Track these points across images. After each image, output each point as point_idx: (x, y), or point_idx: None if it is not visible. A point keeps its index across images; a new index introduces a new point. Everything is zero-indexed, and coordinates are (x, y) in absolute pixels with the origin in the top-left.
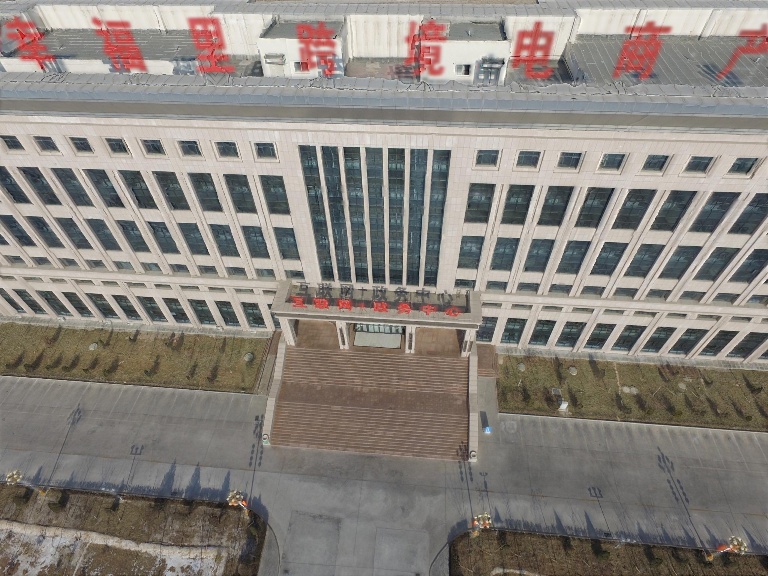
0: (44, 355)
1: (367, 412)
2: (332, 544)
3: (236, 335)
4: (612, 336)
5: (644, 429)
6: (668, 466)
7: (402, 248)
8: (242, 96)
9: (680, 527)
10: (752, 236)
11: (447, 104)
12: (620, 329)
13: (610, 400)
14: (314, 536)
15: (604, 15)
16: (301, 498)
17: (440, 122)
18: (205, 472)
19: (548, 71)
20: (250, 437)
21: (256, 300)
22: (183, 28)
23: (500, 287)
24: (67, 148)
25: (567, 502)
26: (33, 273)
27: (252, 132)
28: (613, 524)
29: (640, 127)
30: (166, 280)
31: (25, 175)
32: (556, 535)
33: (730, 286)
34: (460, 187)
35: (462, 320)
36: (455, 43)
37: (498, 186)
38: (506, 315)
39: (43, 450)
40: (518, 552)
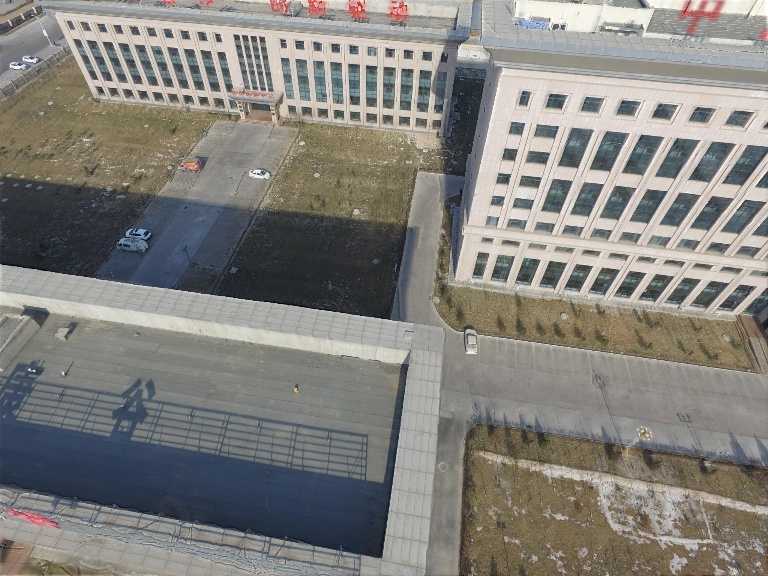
0: (522, 321)
1: None
2: None
3: (700, 316)
4: None
5: None
6: None
7: None
8: None
9: None
10: None
11: None
12: None
13: None
14: None
15: None
16: None
17: None
18: (767, 444)
19: None
20: None
21: (759, 283)
22: None
23: None
24: (759, 124)
25: None
26: (550, 241)
27: None
28: None
29: None
30: (691, 257)
31: (671, 147)
32: None
33: None
34: None
35: None
36: None
37: None
38: None
39: (592, 411)
40: None
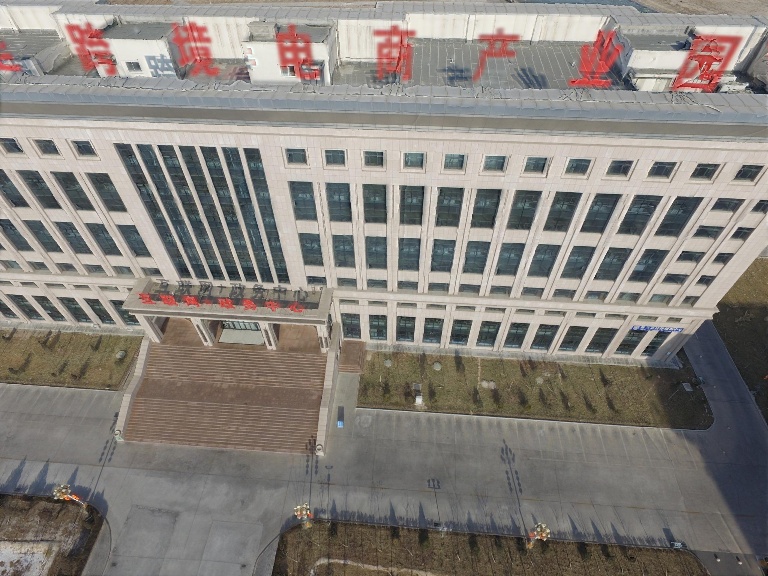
0: None
1: (222, 407)
2: (165, 537)
3: (112, 333)
4: (473, 332)
5: (494, 422)
6: (509, 458)
7: (246, 245)
8: (30, 94)
9: (508, 516)
10: (567, 233)
11: (226, 103)
12: (477, 325)
13: (467, 394)
14: (149, 530)
15: (437, 19)
16: (144, 492)
17: (236, 121)
18: (53, 468)
19: (384, 73)
20: (106, 433)
21: (123, 298)
22: (36, 28)
23: (353, 284)
24: None
25: (404, 493)
26: None
27: (64, 130)
28: (444, 514)
29: (423, 127)
30: (28, 278)
31: None
32: (387, 525)
33: (565, 282)
34: (279, 185)
35: (308, 316)
36: (274, 45)
37: (315, 184)
38: (366, 312)
39: None
40: (346, 542)
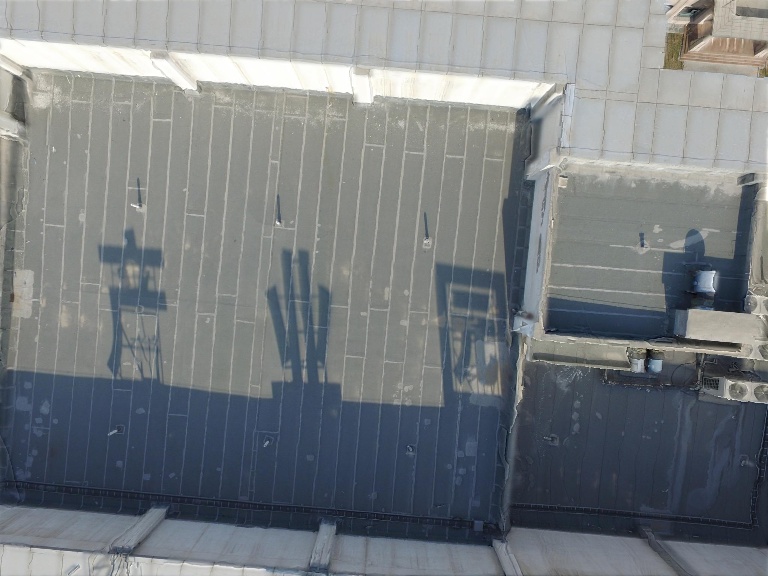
0: None
1: None
2: None
3: None
4: None
5: None
6: None
7: None
8: None
9: None
10: None
11: None
12: None
13: None
14: None
15: (67, 48)
16: None
17: None
18: None
19: (4, 183)
20: None
21: None
22: None
23: None
24: None
25: None
26: None
27: None
28: None
29: None
30: None
31: None
32: None
33: None
34: None
35: None
36: None
37: None
38: None
39: None
40: None
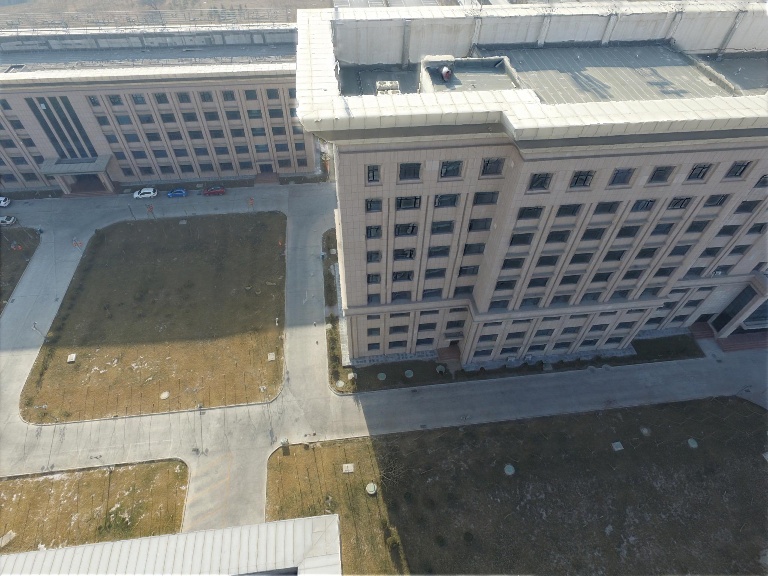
0: None
1: None
2: None
3: None
4: None
5: None
6: None
7: None
8: None
9: None
10: None
11: None
12: None
13: None
14: None
15: None
16: None
17: None
18: None
19: None
20: None
21: None
22: None
23: None
24: None
25: None
26: None
27: None
28: None
29: None
30: None
31: None
32: None
33: None
34: None
35: None
36: None
37: None
38: None
39: None
40: None
